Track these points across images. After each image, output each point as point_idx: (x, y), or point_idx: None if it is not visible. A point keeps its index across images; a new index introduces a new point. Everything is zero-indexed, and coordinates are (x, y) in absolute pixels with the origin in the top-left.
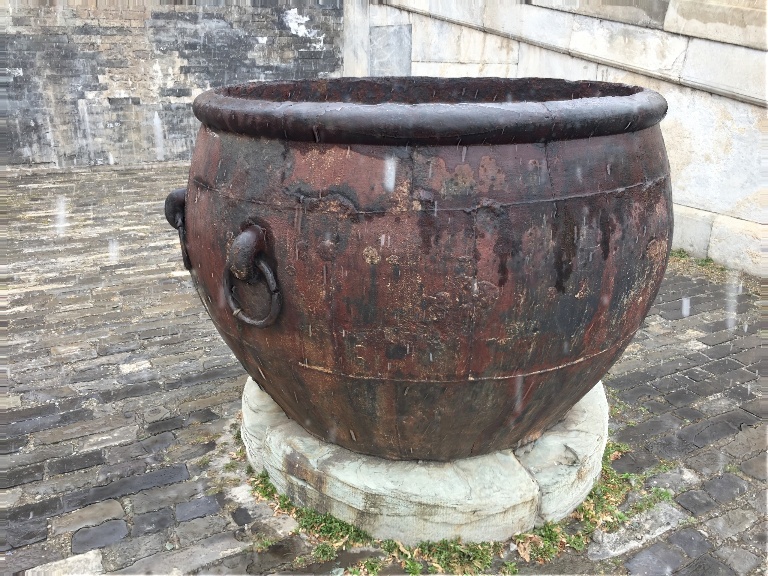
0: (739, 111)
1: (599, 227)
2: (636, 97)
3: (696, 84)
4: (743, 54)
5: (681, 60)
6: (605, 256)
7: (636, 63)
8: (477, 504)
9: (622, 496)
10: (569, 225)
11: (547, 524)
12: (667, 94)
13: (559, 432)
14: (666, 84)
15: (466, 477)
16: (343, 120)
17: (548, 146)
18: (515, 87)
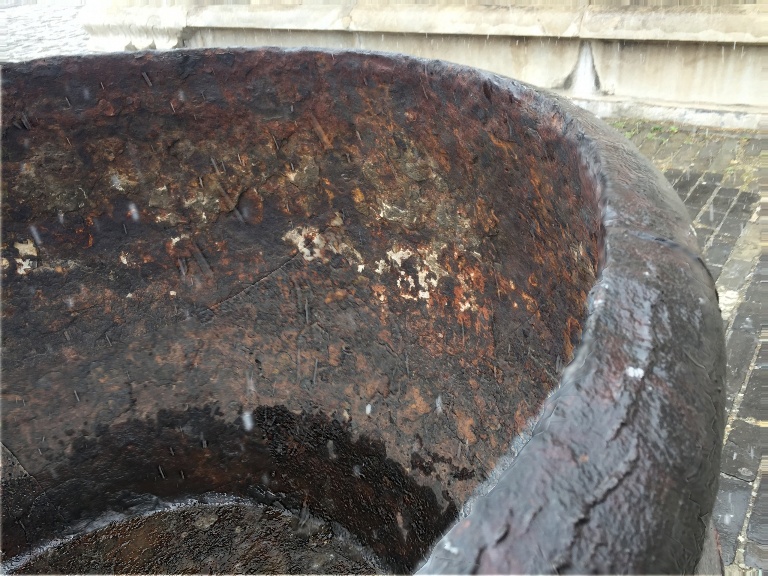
0: None
1: None
2: None
3: None
4: None
5: None
6: None
7: None
8: None
9: None
10: None
11: None
12: None
13: None
14: None
15: None
16: (66, 79)
17: None
18: None
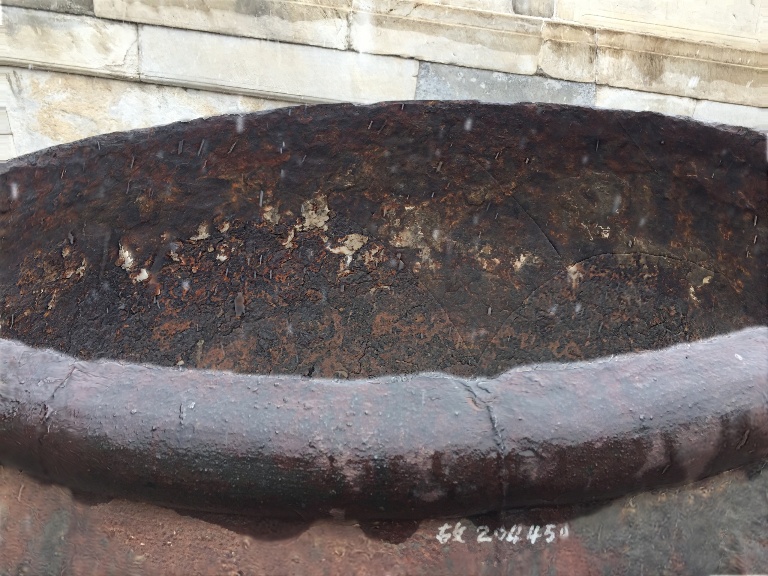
0: (226, 104)
1: None
2: None
3: (165, 80)
4: (215, 41)
5: (134, 53)
6: None
7: (66, 60)
8: None
9: None
10: None
11: None
12: (125, 95)
13: None
14: (119, 83)
15: None
16: None
17: None
18: (268, 125)
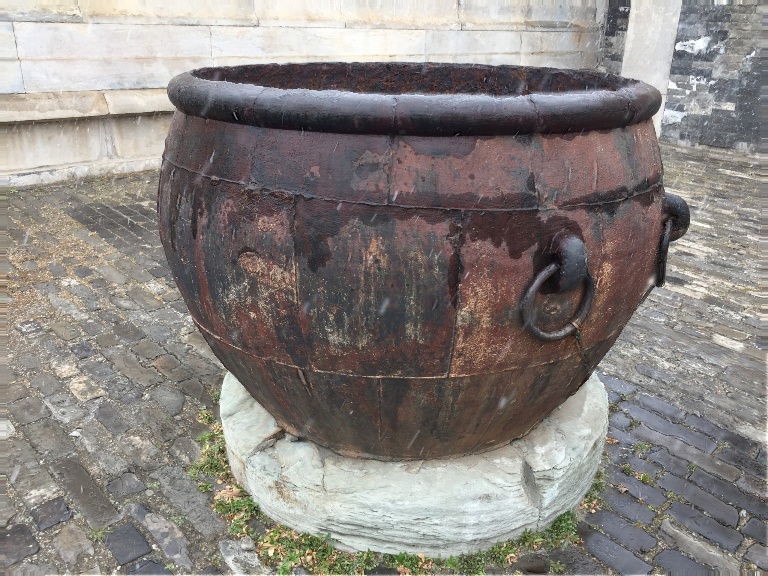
0: None
1: (192, 204)
2: (277, 90)
3: None
4: None
5: None
6: (194, 235)
7: None
8: (223, 426)
9: (323, 572)
10: (177, 191)
11: (252, 501)
12: None
13: (318, 454)
14: None
15: (244, 409)
16: None
17: (187, 118)
18: None
